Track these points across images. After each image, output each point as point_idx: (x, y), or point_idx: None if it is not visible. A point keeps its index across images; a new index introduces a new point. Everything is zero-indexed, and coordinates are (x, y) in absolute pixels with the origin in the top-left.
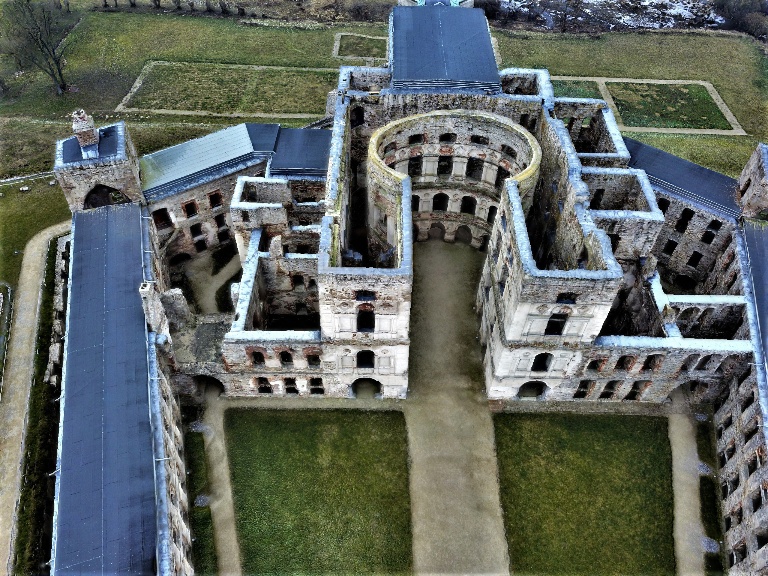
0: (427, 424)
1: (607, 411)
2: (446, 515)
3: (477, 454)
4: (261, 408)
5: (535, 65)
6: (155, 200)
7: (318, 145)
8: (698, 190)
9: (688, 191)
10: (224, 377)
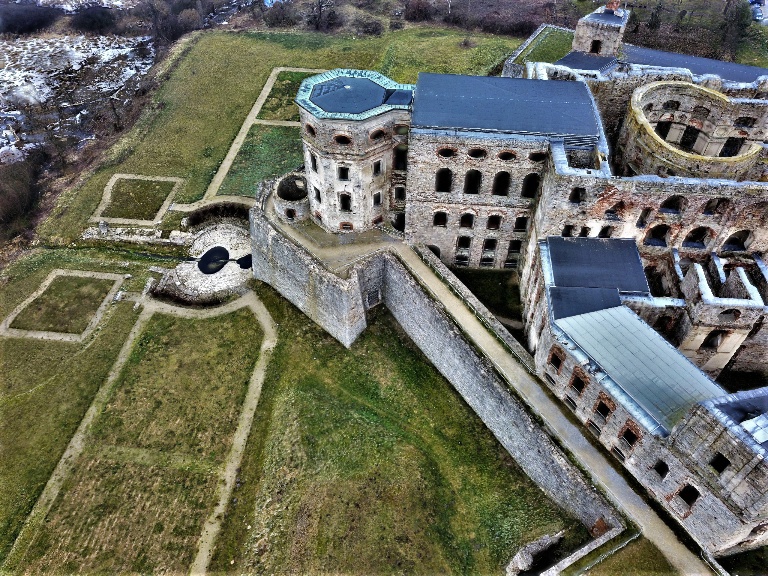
0: None
1: None
2: None
3: None
4: None
5: (203, 154)
6: None
7: (587, 255)
8: (596, 66)
9: (599, 69)
10: None
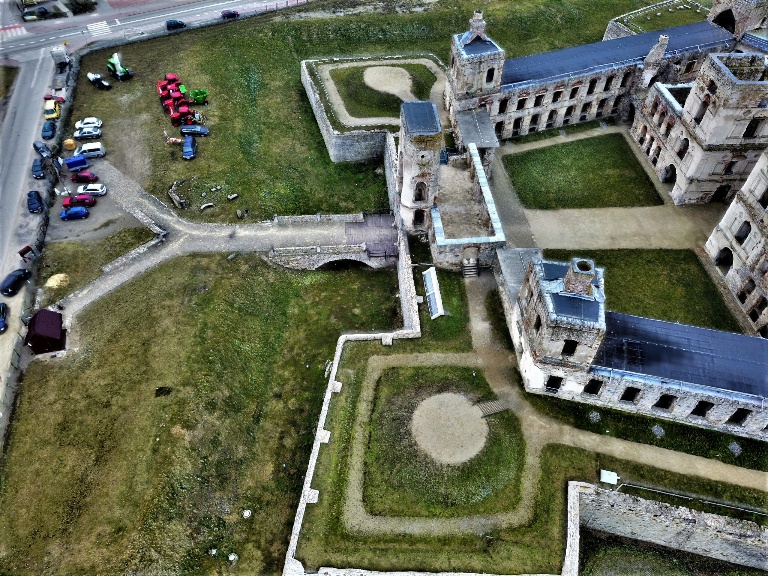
0: (662, 216)
1: (739, 321)
2: (600, 223)
3: (652, 239)
4: (630, 146)
5: None
6: (744, 42)
7: None
8: None
9: None
10: (637, 113)
